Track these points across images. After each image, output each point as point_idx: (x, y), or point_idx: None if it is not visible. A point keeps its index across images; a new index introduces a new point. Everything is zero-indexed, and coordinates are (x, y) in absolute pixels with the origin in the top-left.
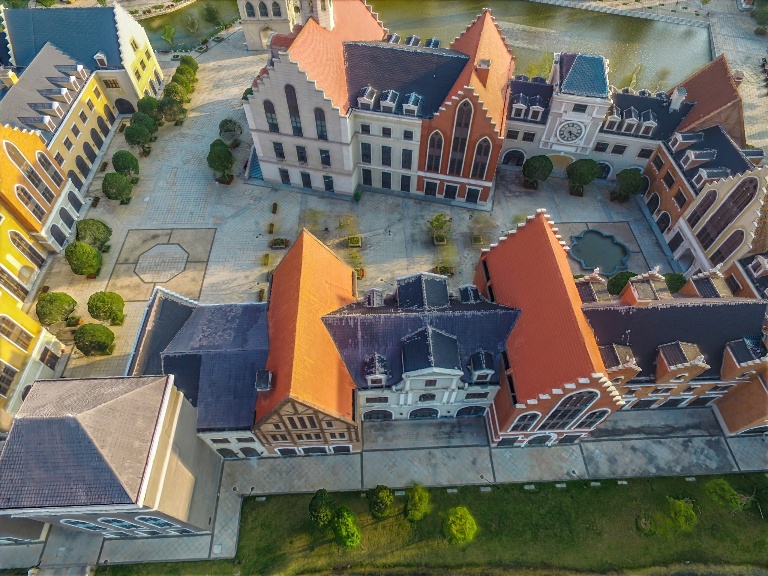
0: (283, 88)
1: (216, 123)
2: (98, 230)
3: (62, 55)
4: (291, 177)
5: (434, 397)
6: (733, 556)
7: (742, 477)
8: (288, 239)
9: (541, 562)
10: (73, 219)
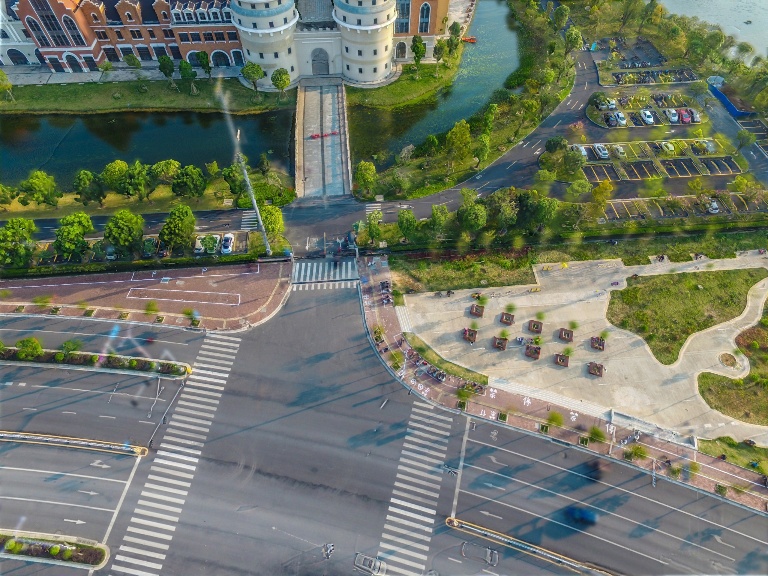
0: None
1: None
2: None
3: None
4: None
5: (7, 35)
6: (156, 105)
7: (181, 80)
8: None
9: (55, 109)
10: None
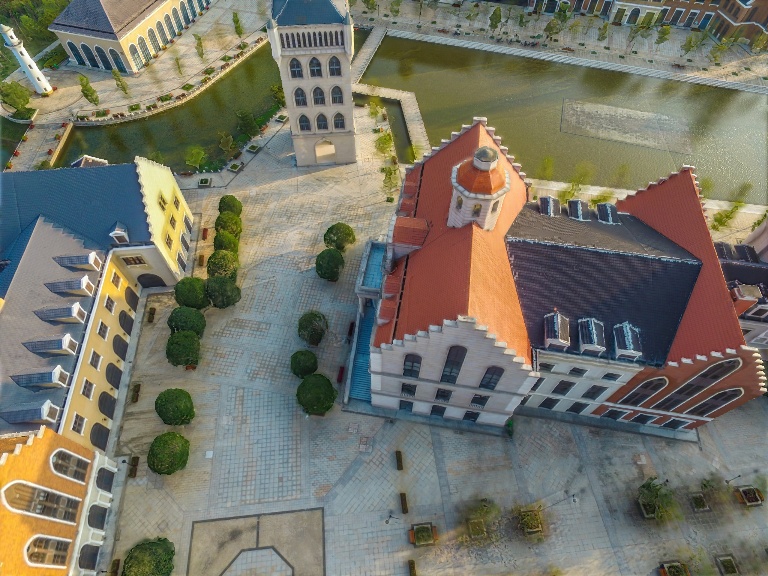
0: (448, 347)
1: (281, 298)
2: (158, 567)
3: (62, 235)
4: (415, 407)
5: None
6: None
7: None
8: (433, 523)
9: None
10: (105, 508)
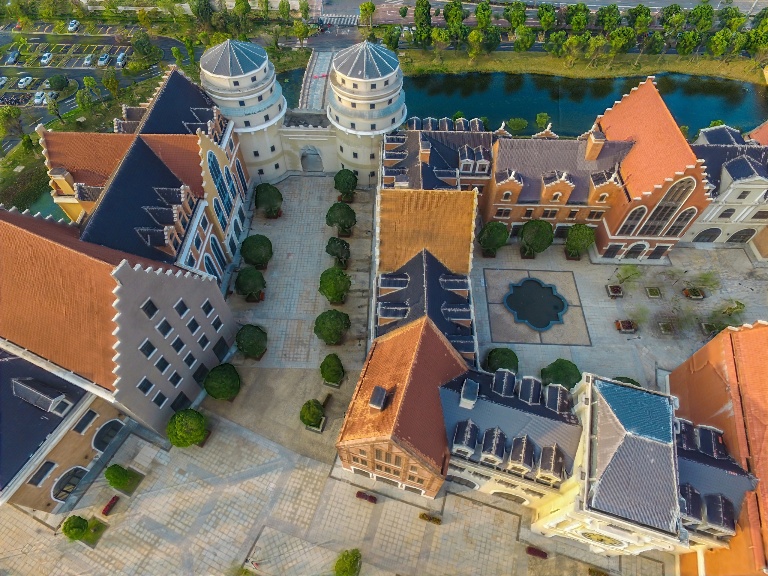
0: None
1: None
2: None
3: None
4: None
5: None
6: None
7: None
8: None
9: None
10: None
